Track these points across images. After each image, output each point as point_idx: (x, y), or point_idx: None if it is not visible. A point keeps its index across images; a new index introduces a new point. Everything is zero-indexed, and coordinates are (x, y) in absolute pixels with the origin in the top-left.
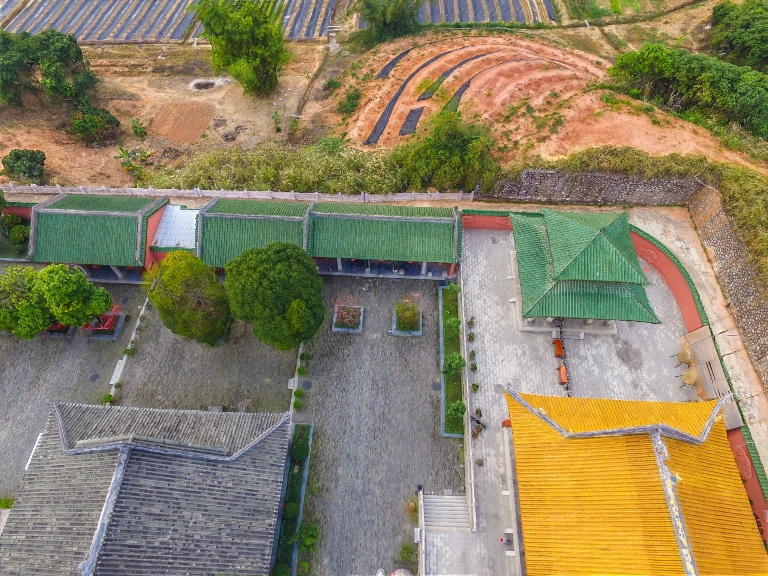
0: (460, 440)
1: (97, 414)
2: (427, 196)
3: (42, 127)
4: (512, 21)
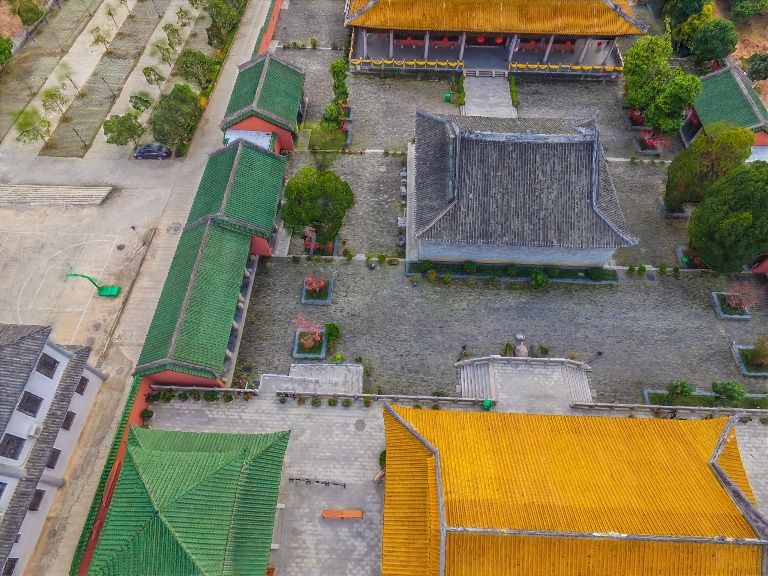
0: None
1: None
2: None
3: None
4: None
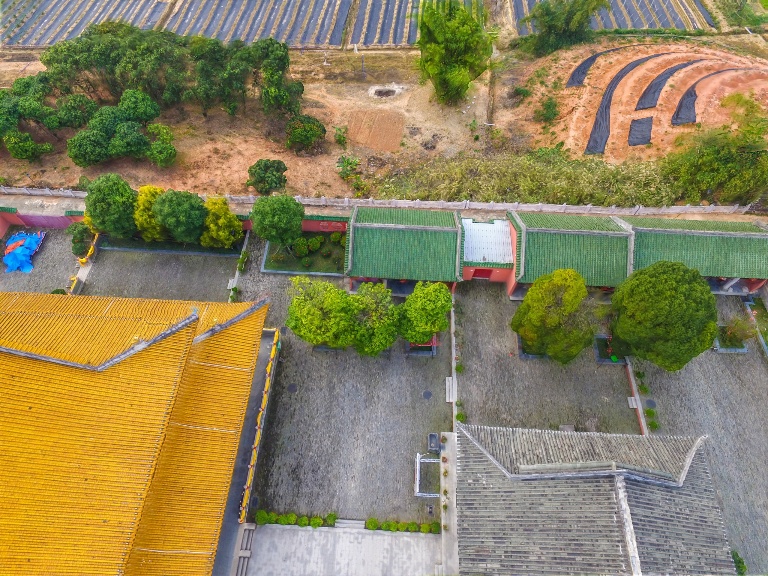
0: None
1: (505, 436)
2: (700, 209)
3: (254, 136)
4: (672, 28)
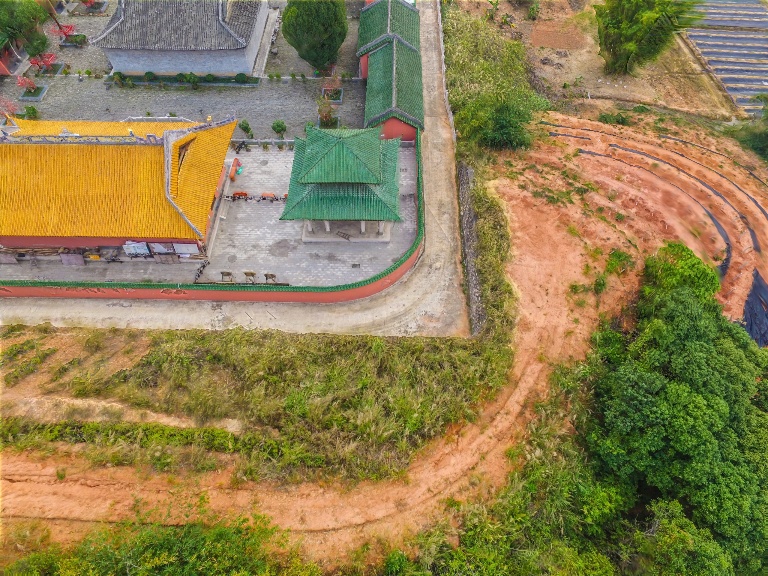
0: None
1: None
2: None
3: None
4: None
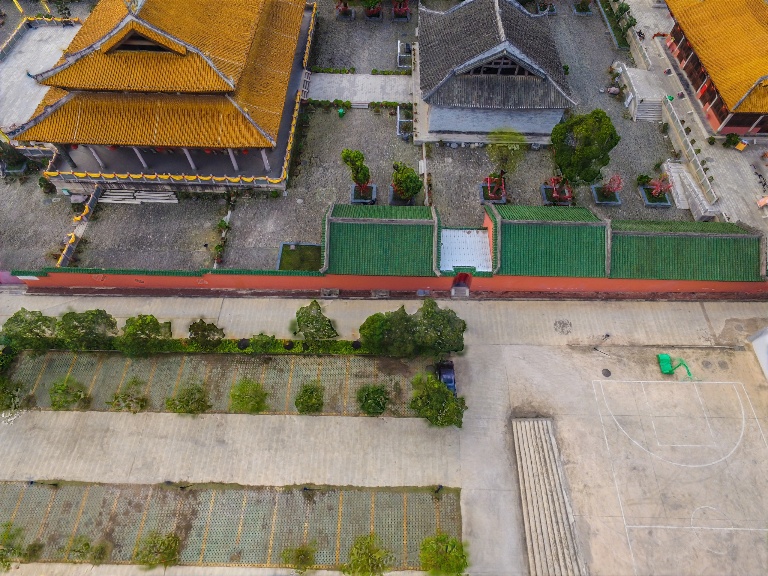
0: (628, 51)
1: None
2: None
3: None
4: None
